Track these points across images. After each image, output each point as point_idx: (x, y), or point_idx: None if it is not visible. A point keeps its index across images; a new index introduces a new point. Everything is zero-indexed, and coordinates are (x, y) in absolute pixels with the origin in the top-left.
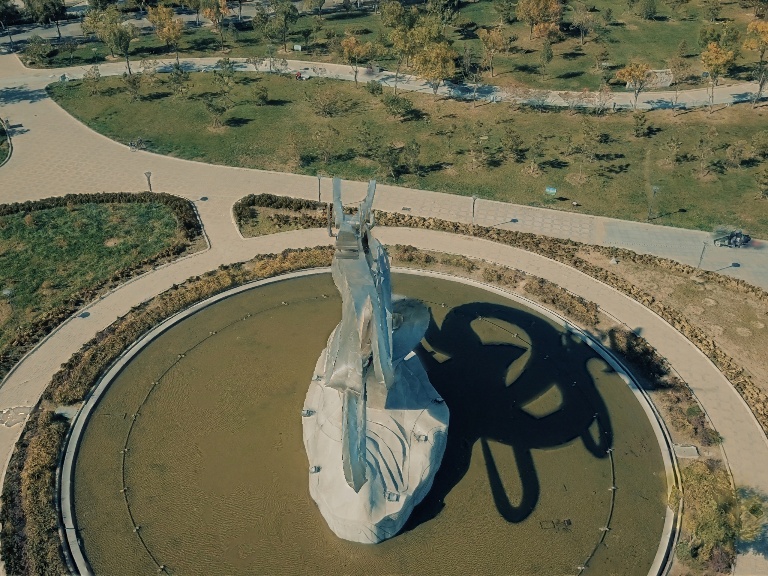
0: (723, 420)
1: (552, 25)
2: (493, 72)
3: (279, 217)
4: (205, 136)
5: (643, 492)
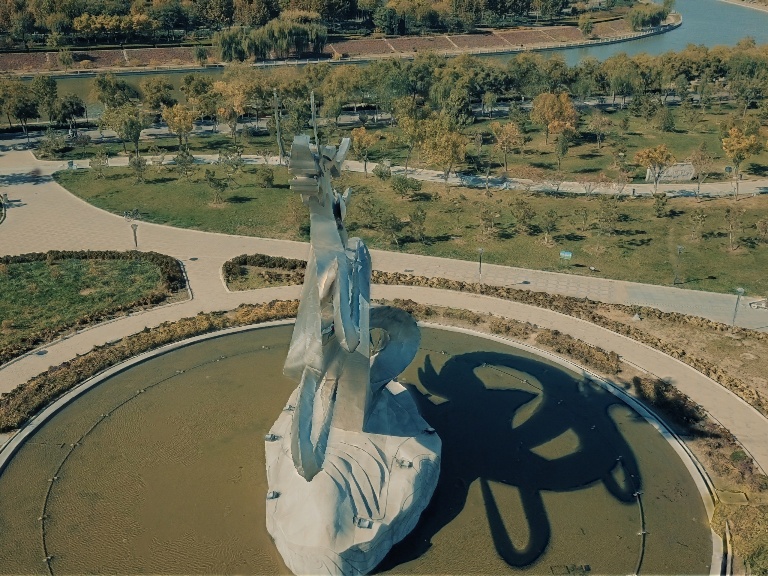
0: None
1: (567, 125)
2: (507, 166)
3: (270, 274)
4: (204, 210)
5: (681, 538)
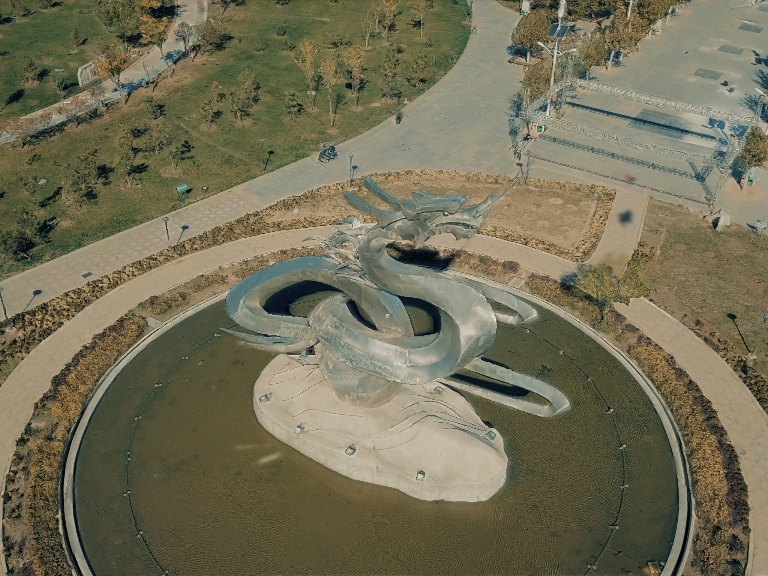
0: (499, 253)
1: None
2: None
3: None
4: None
5: None
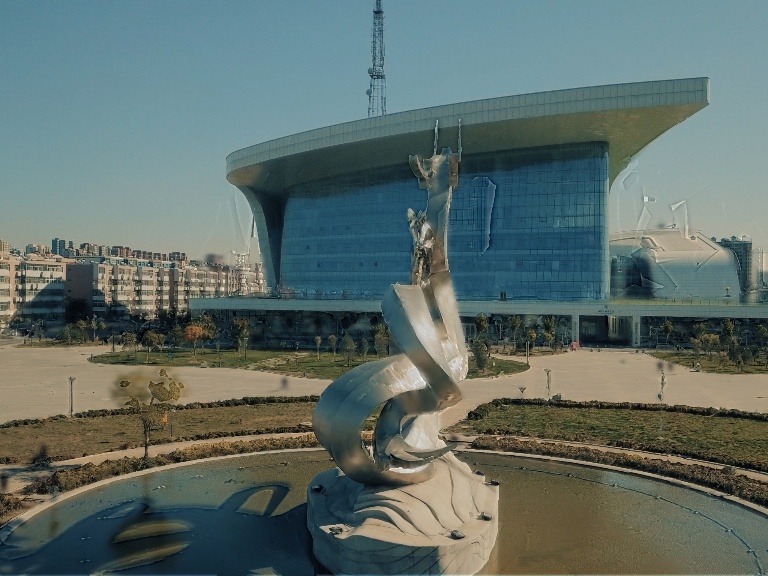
0: None
1: None
2: None
3: None
4: None
5: None
